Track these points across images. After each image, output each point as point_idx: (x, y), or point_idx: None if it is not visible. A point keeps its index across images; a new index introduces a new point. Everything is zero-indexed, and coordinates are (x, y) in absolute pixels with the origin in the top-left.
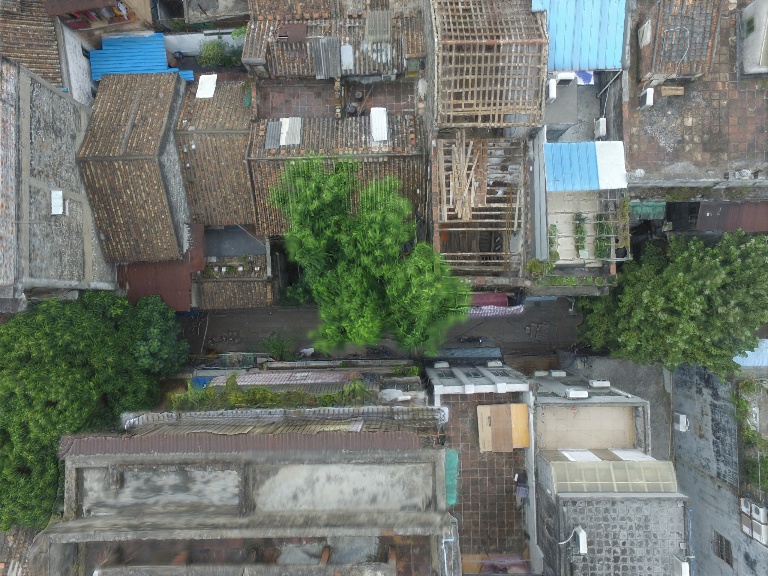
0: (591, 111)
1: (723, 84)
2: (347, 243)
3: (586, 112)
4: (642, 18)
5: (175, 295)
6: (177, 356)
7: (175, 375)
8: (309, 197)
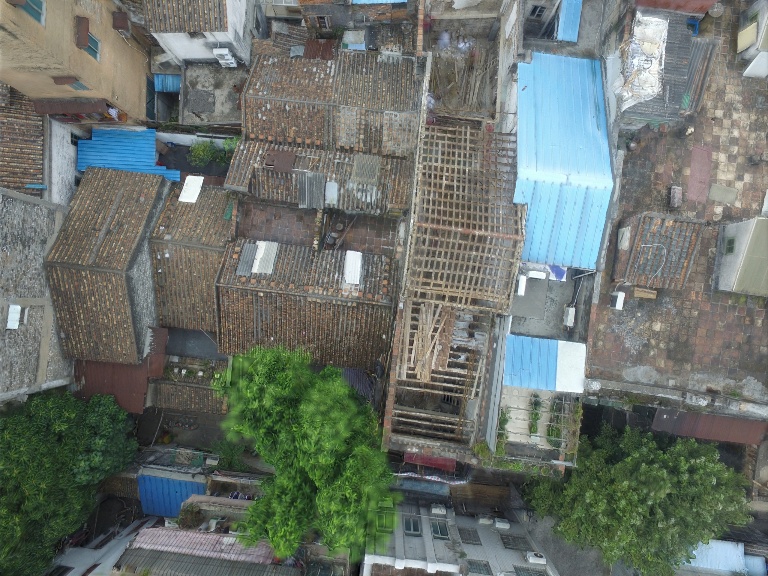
0: (564, 291)
1: (697, 294)
2: (285, 438)
3: (559, 292)
4: (625, 215)
5: (130, 396)
6: (123, 457)
7: (119, 474)
8: (250, 397)
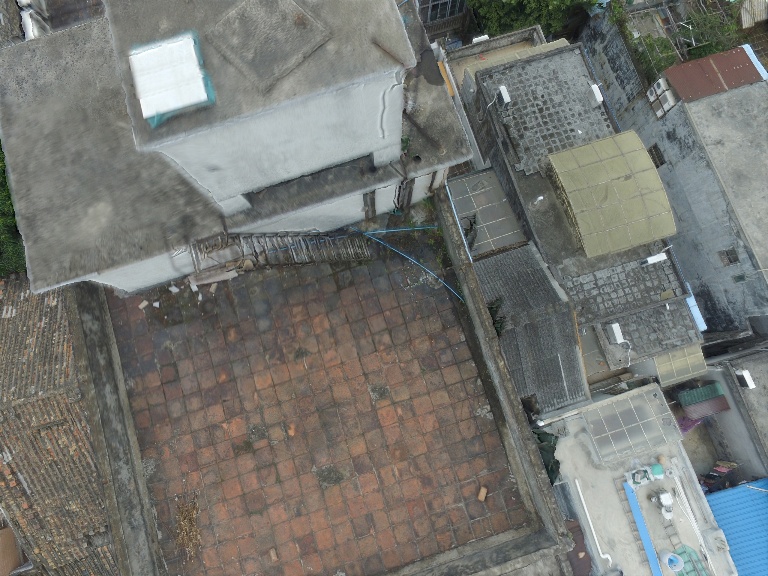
0: None
1: None
2: None
3: None
4: None
5: None
6: None
7: None
8: None
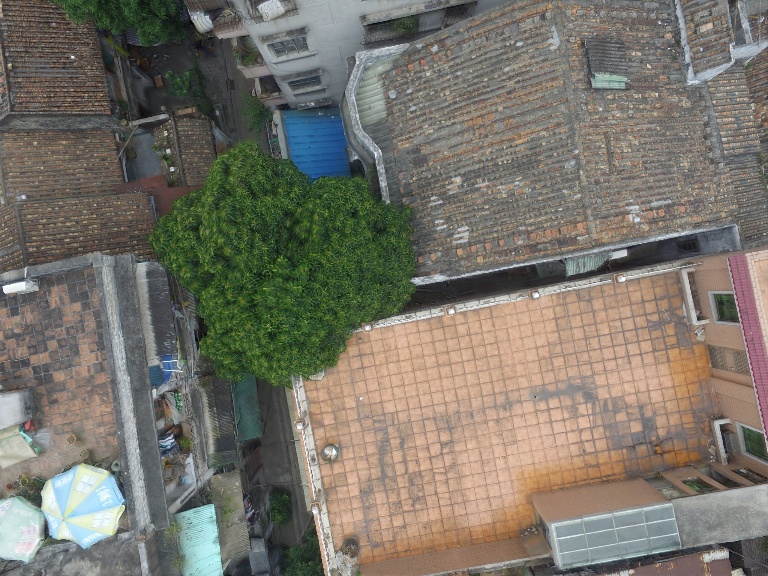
0: None
1: None
2: None
3: None
4: None
5: None
6: None
7: None
8: None
